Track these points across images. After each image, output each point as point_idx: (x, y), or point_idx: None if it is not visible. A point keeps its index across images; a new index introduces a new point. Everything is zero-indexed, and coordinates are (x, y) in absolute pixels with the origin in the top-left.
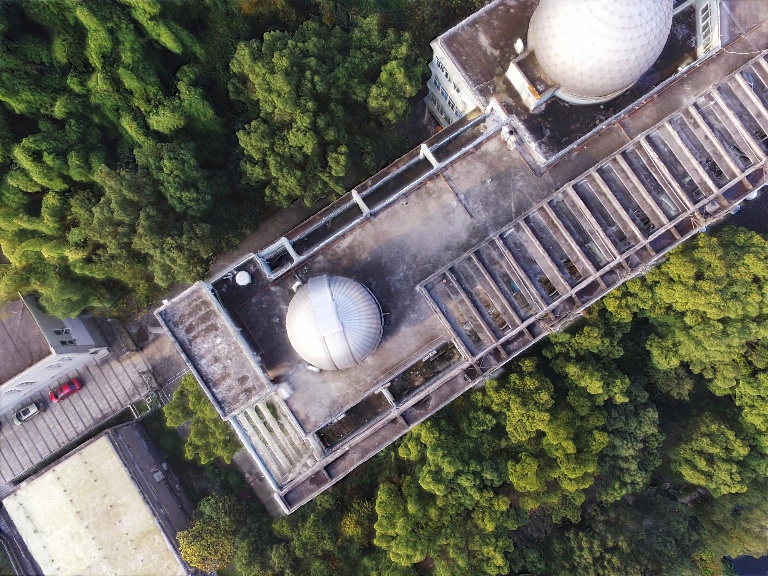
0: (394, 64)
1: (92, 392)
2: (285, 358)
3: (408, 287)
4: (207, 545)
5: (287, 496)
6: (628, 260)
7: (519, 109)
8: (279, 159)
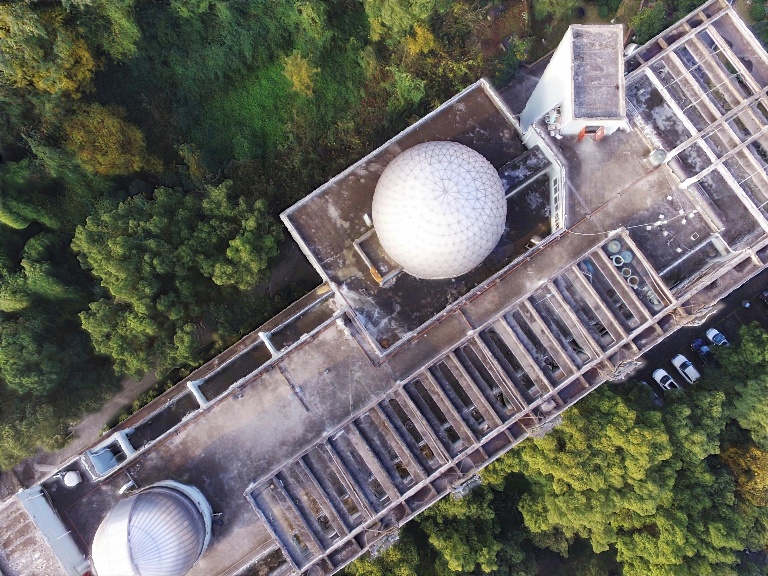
0: (238, 242)
1: None
2: None
3: (242, 485)
4: None
5: None
6: (460, 465)
7: (369, 284)
8: (120, 342)
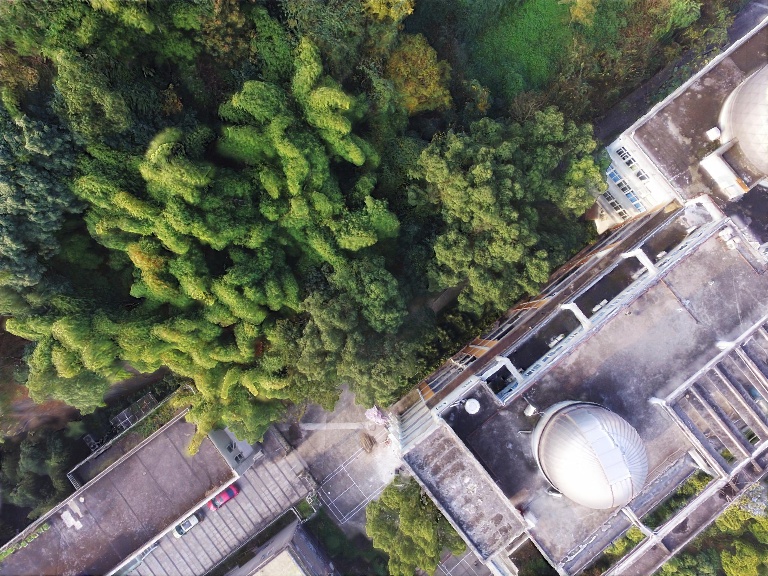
0: (591, 164)
1: (249, 496)
2: (523, 485)
3: (640, 400)
4: None
5: None
6: None
7: (718, 198)
8: (483, 272)
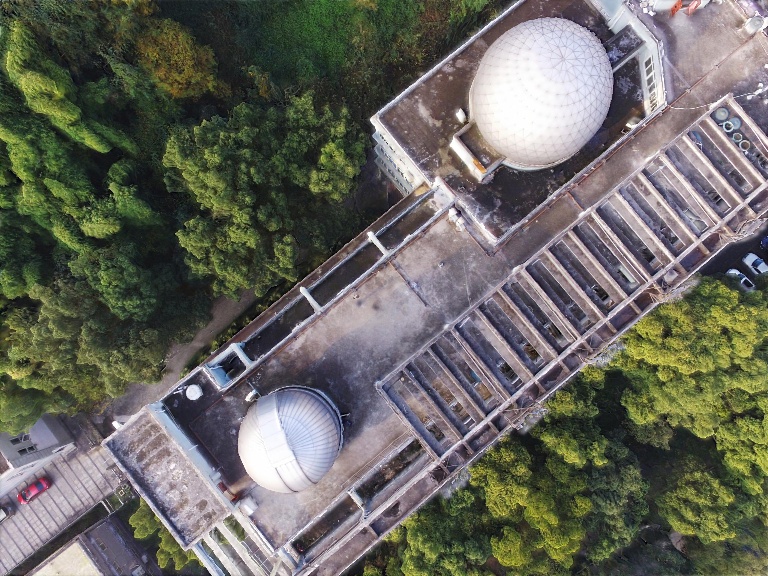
0: (333, 147)
1: (62, 490)
2: None
3: (367, 384)
4: None
5: None
6: (589, 340)
7: (467, 181)
8: (222, 257)
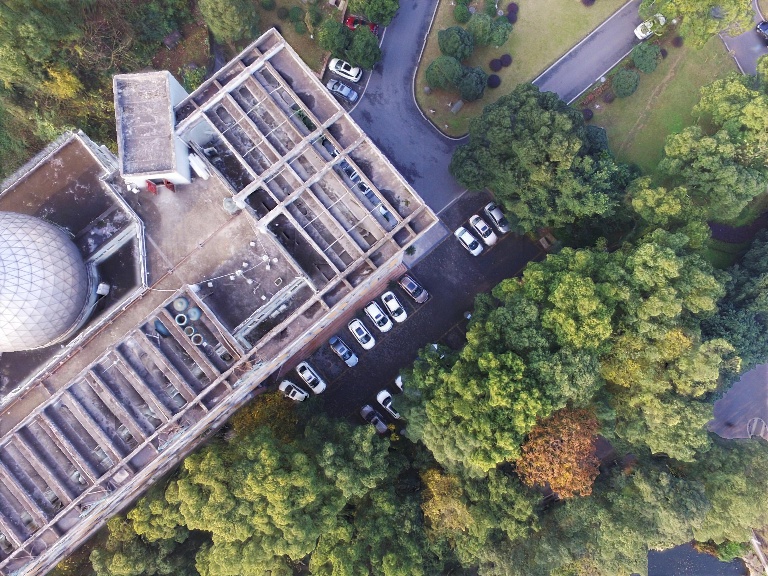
0: None
1: None
2: None
3: None
4: None
5: None
6: (30, 548)
7: None
8: None
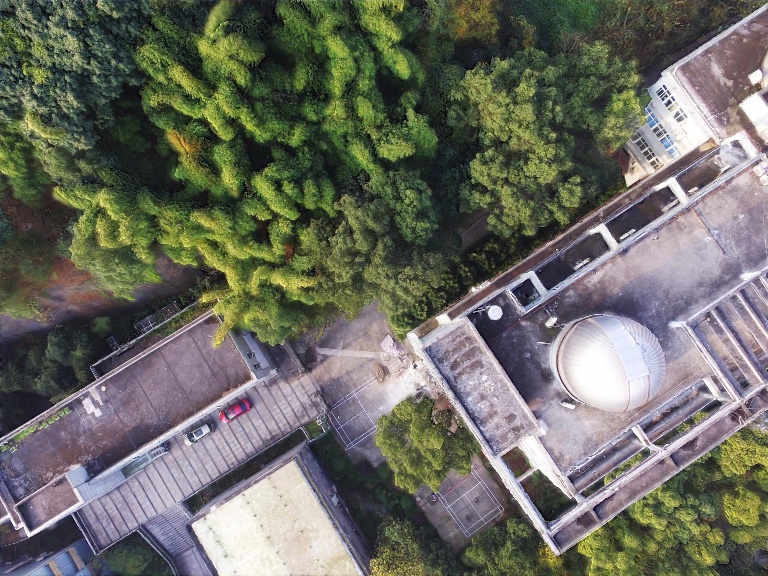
0: (632, 94)
1: (261, 413)
2: (537, 394)
3: (661, 324)
4: (403, 573)
5: (555, 537)
6: None
7: (754, 141)
8: (515, 190)
